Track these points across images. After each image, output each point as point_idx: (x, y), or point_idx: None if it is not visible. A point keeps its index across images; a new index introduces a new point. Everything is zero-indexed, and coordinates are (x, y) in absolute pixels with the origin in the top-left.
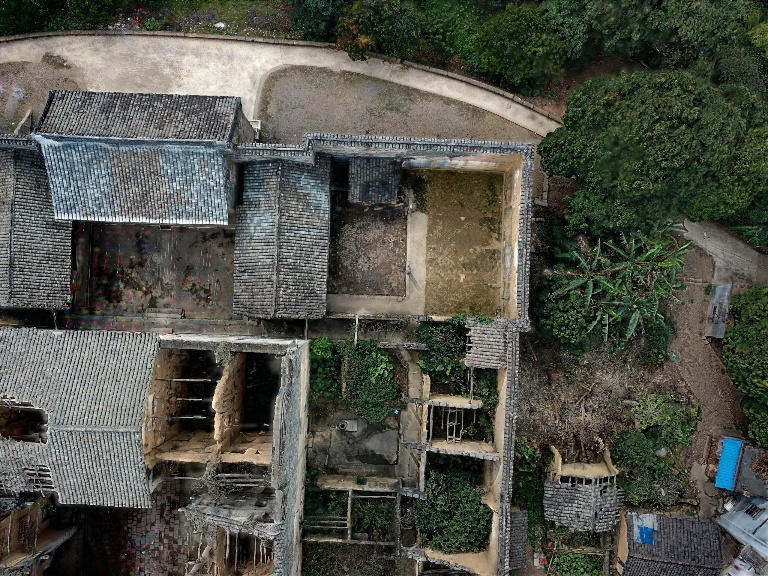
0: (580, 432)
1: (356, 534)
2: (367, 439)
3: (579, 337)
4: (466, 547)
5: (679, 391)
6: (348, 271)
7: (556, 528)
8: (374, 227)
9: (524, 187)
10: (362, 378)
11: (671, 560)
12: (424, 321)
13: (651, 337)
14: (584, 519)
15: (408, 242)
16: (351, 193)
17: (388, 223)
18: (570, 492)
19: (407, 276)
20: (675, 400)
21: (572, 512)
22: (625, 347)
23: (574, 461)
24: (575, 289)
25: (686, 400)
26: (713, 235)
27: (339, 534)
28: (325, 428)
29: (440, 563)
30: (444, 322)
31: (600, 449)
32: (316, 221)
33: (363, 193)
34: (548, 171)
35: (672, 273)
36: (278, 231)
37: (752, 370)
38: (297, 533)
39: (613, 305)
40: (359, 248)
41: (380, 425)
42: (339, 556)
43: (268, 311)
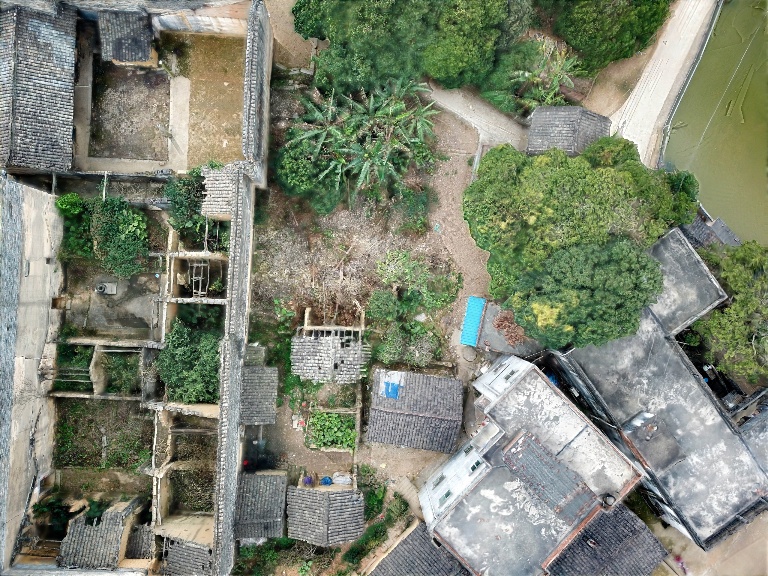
0: (337, 294)
1: (108, 393)
2: (127, 302)
3: (310, 184)
4: (204, 397)
5: (439, 257)
6: (110, 135)
7: (306, 385)
8: (137, 91)
9: (250, 30)
10: (111, 234)
11: (412, 412)
12: (167, 173)
13: (408, 202)
14: (324, 370)
15: (171, 106)
16: (104, 50)
17: (152, 88)
18: (313, 345)
19: (169, 140)
20: (434, 266)
21: (314, 364)
22: (382, 211)
23: (331, 323)
24: (310, 139)
25: (445, 266)
26: (478, 108)
27: (88, 391)
28: (84, 291)
29: (174, 410)
30: (186, 174)
31: (357, 312)
32: (60, 73)
33: (116, 51)
34: (303, 33)
35: (420, 133)
36: (14, 78)
37: (476, 217)
38: (31, 381)
39: (343, 153)
40: (122, 112)
41: (140, 289)
42: (97, 418)
43: (5, 159)
